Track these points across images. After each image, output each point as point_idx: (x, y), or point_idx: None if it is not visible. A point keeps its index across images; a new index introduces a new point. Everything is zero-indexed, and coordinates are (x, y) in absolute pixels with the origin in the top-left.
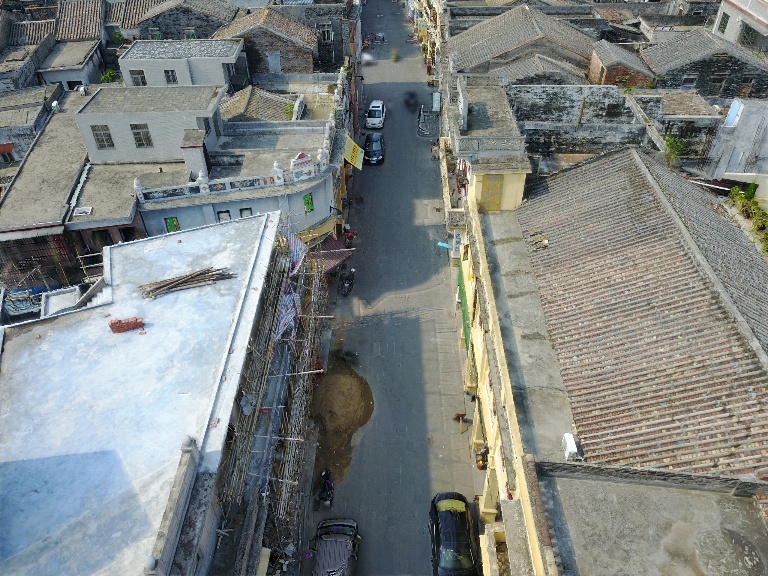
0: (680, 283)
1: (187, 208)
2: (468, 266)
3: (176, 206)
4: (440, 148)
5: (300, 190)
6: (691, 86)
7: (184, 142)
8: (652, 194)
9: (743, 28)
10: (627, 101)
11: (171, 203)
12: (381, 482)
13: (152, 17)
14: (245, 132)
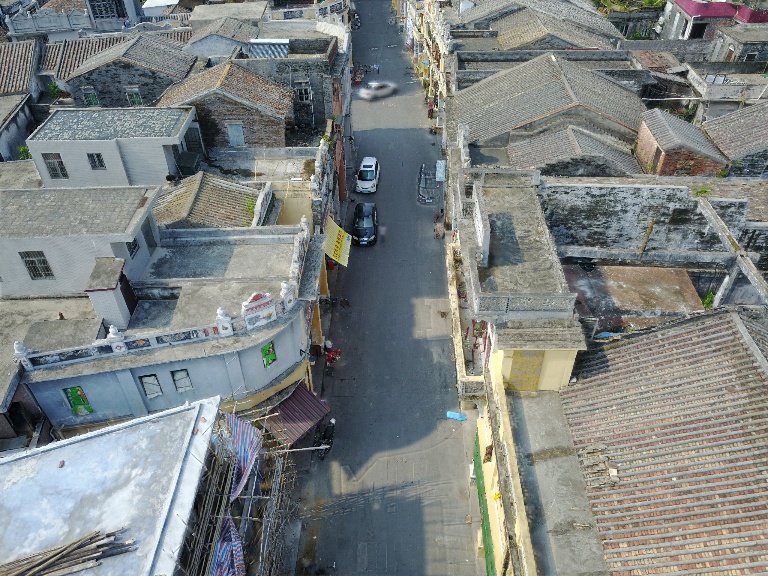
0: None
1: (94, 375)
2: (491, 473)
3: (77, 375)
4: (448, 262)
5: (255, 344)
6: None
7: (90, 281)
8: None
9: None
10: (701, 208)
11: (70, 370)
12: None
13: (84, 73)
14: (189, 242)
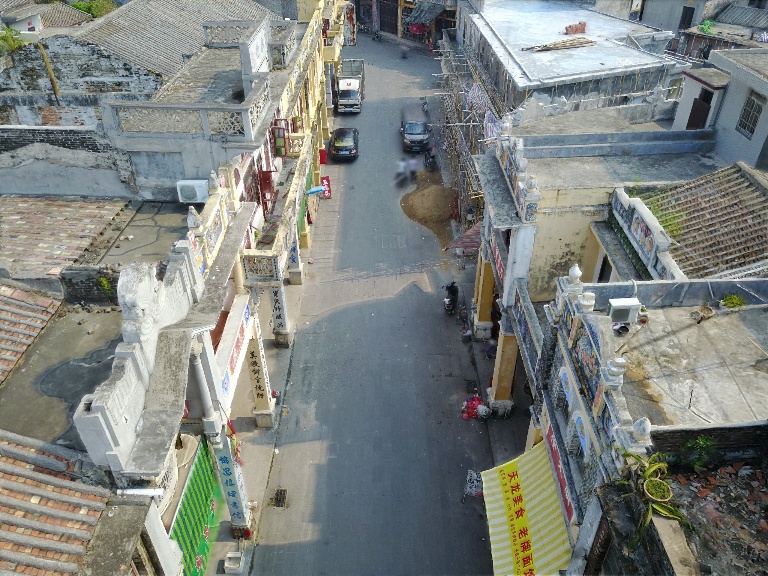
0: (174, 2)
1: None
2: None
3: None
4: None
5: None
6: None
7: None
8: (115, 19)
9: None
10: None
11: None
12: (391, 170)
13: None
14: None
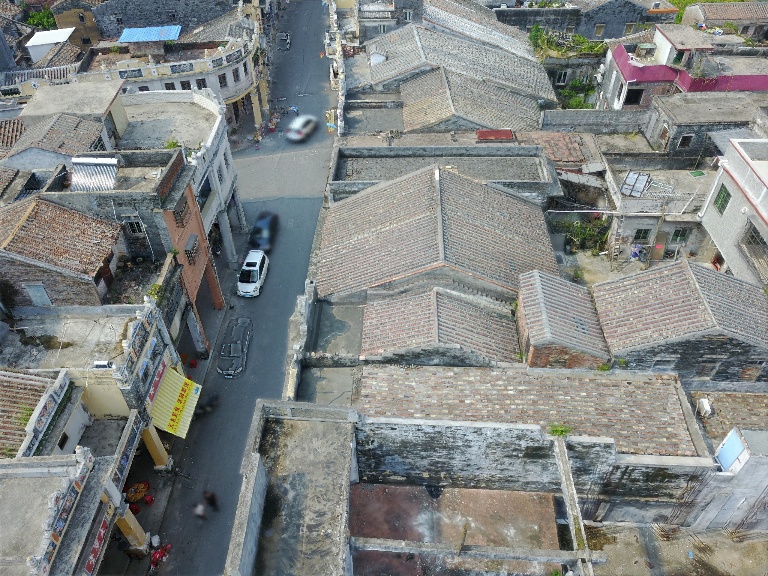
0: None
1: None
2: None
3: None
4: None
5: None
6: (667, 368)
7: None
8: None
9: (750, 226)
10: (555, 454)
11: None
12: None
13: None
14: None
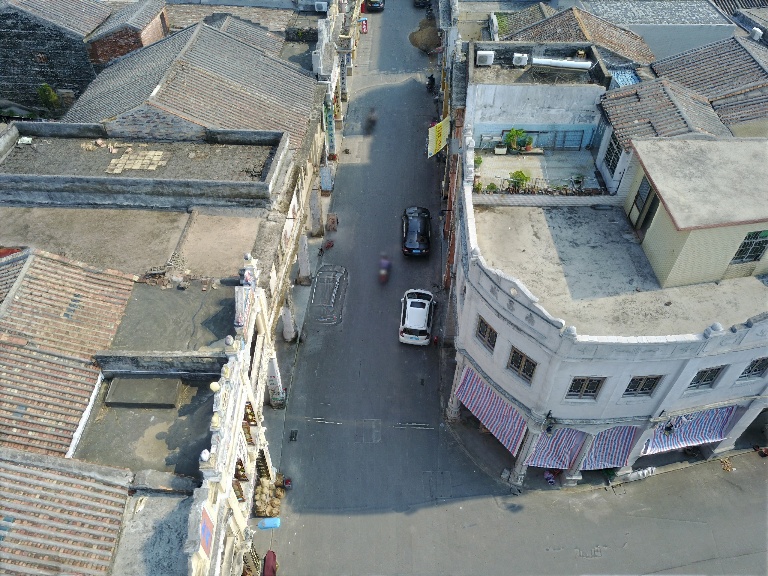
0: None
1: None
2: None
3: None
4: None
5: None
6: None
7: None
8: None
9: None
10: None
11: None
12: None
13: None
14: None
